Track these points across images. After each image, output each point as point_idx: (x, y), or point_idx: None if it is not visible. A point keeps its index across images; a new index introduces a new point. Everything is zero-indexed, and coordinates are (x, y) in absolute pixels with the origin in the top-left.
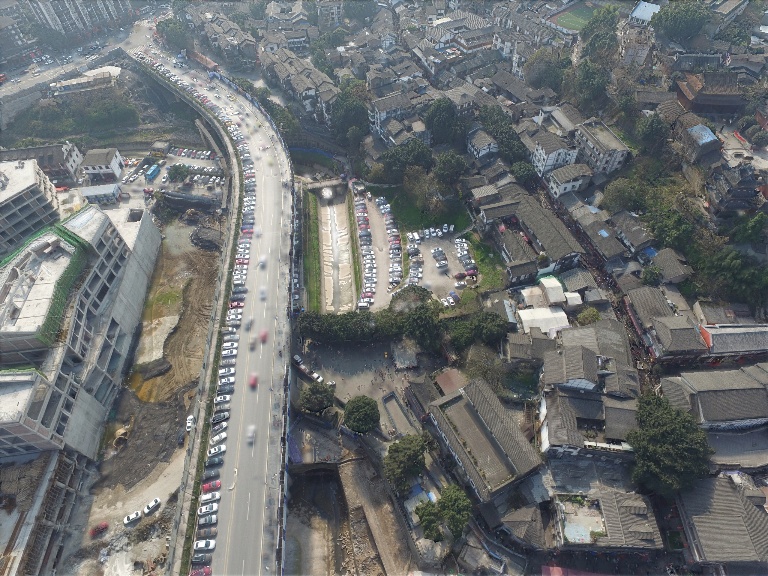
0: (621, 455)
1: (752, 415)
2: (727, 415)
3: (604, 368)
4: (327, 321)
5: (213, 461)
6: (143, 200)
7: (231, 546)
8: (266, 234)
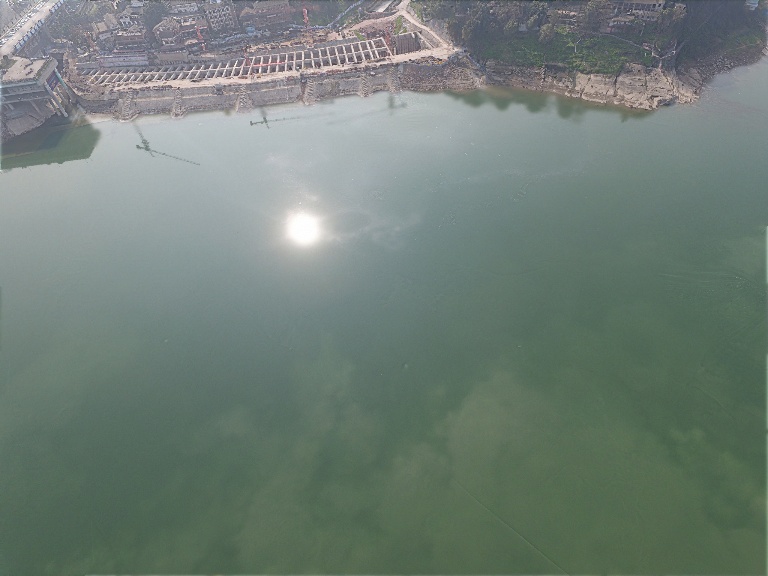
0: (143, 19)
1: (187, 3)
2: (179, 3)
3: (148, 0)
4: (68, 15)
5: (8, 35)
6: (9, 6)
7: (7, 45)
8: (54, 0)
